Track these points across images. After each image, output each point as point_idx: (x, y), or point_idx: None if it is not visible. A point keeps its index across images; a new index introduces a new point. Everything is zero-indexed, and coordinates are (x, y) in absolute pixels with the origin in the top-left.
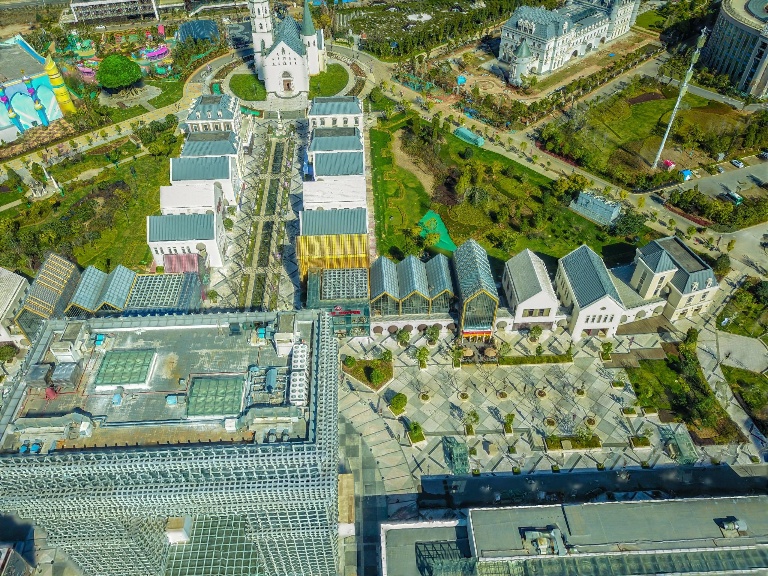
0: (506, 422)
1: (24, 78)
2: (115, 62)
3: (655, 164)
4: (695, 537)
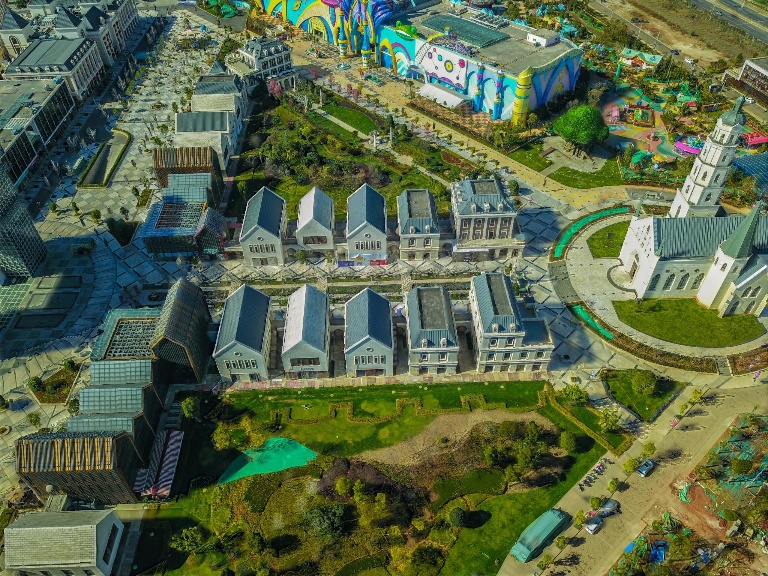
0: None
1: (500, 71)
2: (577, 113)
3: None
4: None
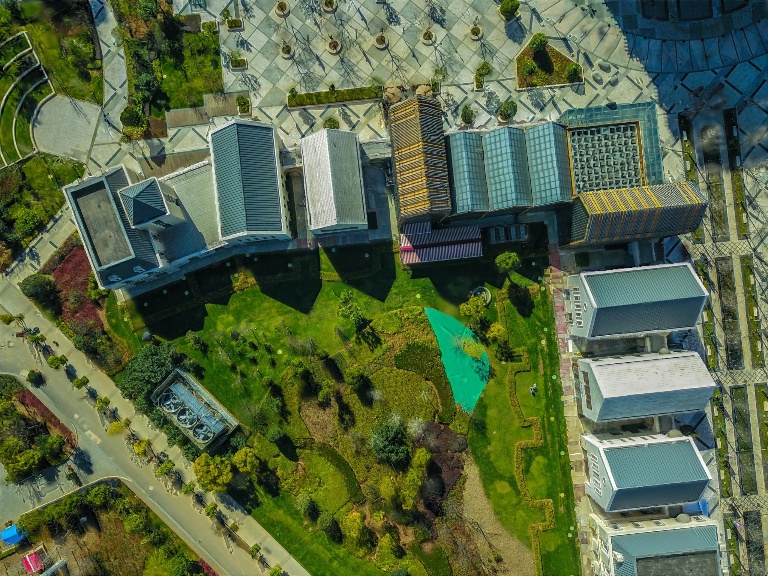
0: (381, 3)
1: None
2: None
3: (57, 565)
4: None
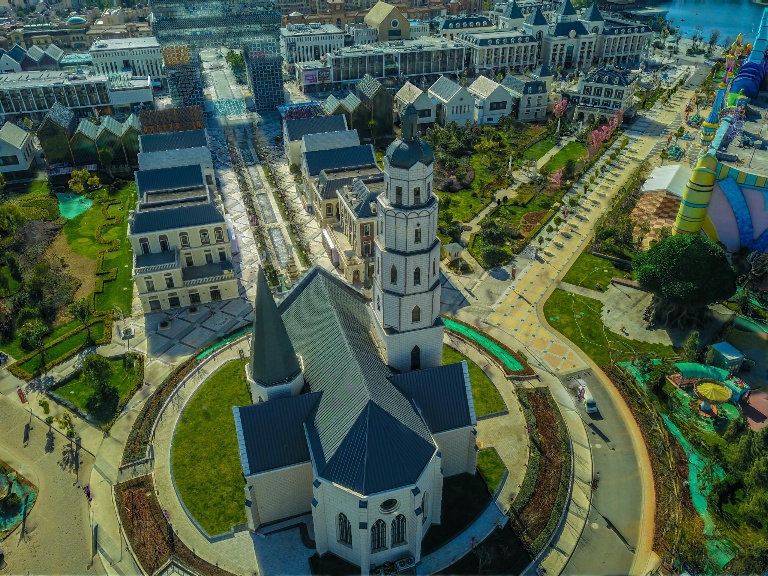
0: None
1: None
2: None
3: None
4: (8, 84)
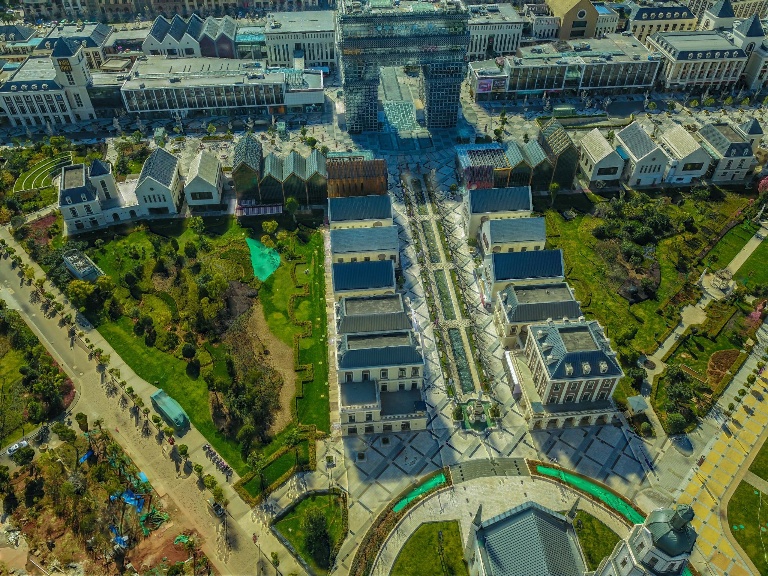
0: None
1: None
2: None
3: None
4: None
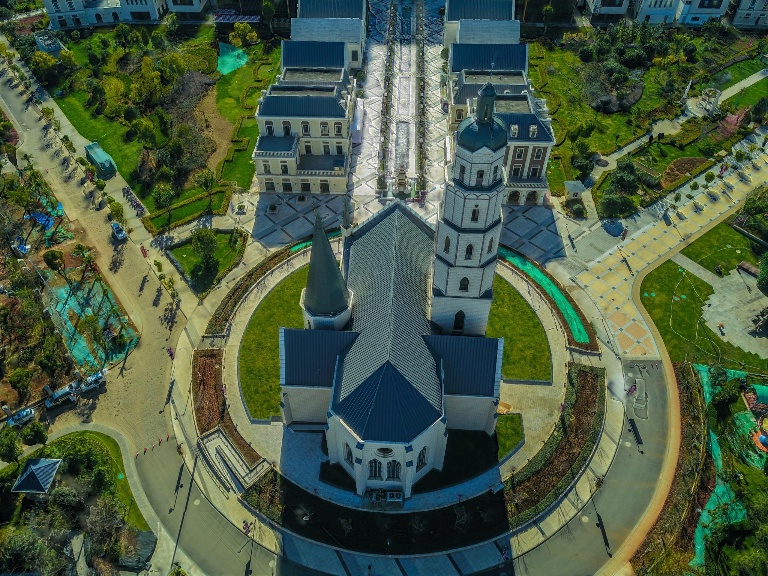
0: None
1: None
2: None
3: None
4: None
